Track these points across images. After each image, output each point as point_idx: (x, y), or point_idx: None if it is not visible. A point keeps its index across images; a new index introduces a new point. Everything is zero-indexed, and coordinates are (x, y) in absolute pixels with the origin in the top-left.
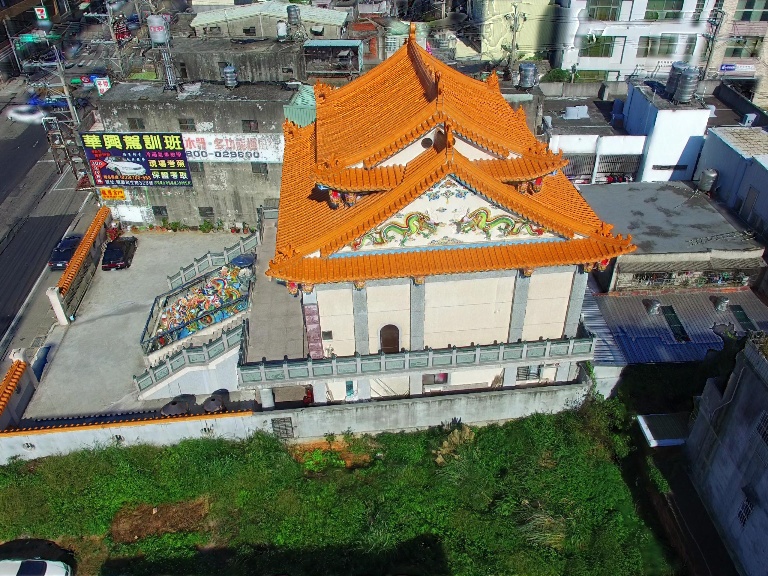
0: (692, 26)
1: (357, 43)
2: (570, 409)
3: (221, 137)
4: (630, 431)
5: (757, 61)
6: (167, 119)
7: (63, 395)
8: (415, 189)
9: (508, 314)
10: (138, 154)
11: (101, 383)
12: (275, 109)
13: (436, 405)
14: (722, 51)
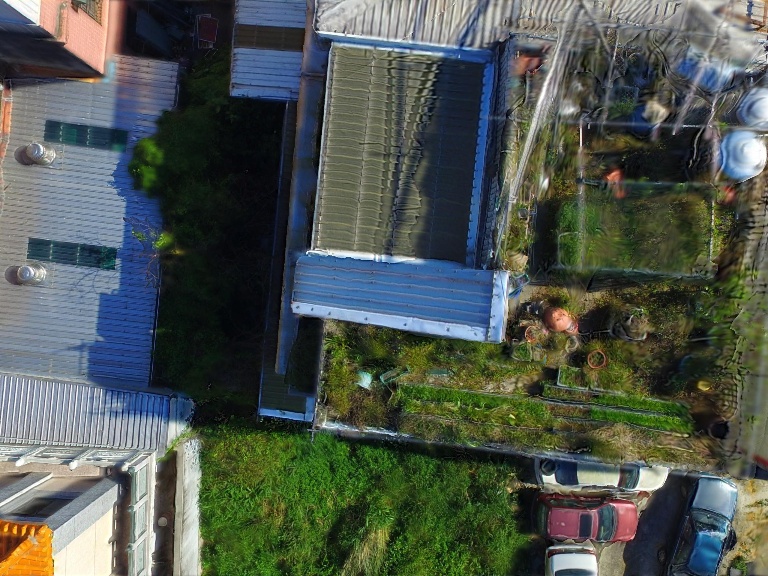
0: None
1: None
2: (199, 453)
3: None
4: None
5: None
6: None
7: None
8: None
9: None
10: None
11: None
12: None
13: None
14: None
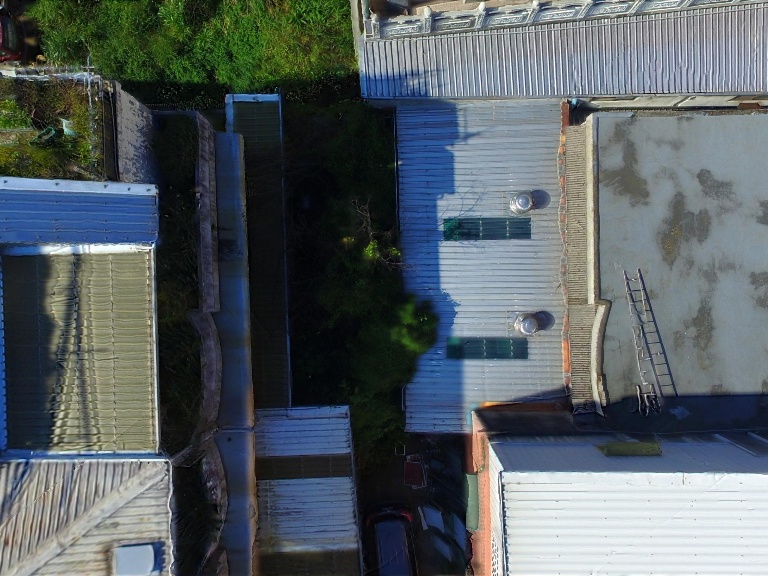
0: None
1: None
2: None
3: None
4: None
5: None
6: None
7: None
8: None
9: None
10: None
11: None
12: None
13: None
14: None
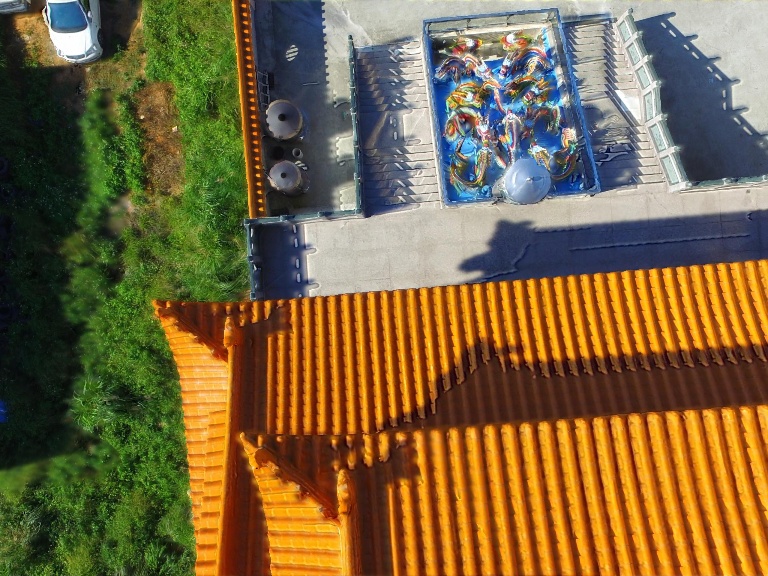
0: None
1: None
2: None
3: None
4: None
5: None
6: None
7: None
8: None
9: None
10: None
11: None
12: None
13: None
14: None
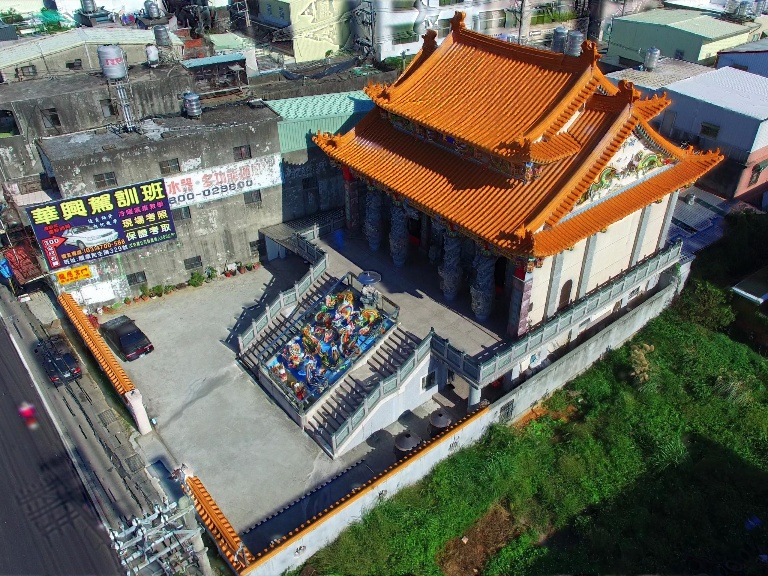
0: (500, 3)
1: (241, 56)
2: (666, 308)
3: (210, 172)
4: (722, 304)
5: (561, 24)
6: (145, 165)
7: (244, 496)
8: (612, 145)
9: (633, 242)
10: (108, 216)
11: (272, 465)
12: (269, 128)
13: (601, 340)
14: (529, 21)
